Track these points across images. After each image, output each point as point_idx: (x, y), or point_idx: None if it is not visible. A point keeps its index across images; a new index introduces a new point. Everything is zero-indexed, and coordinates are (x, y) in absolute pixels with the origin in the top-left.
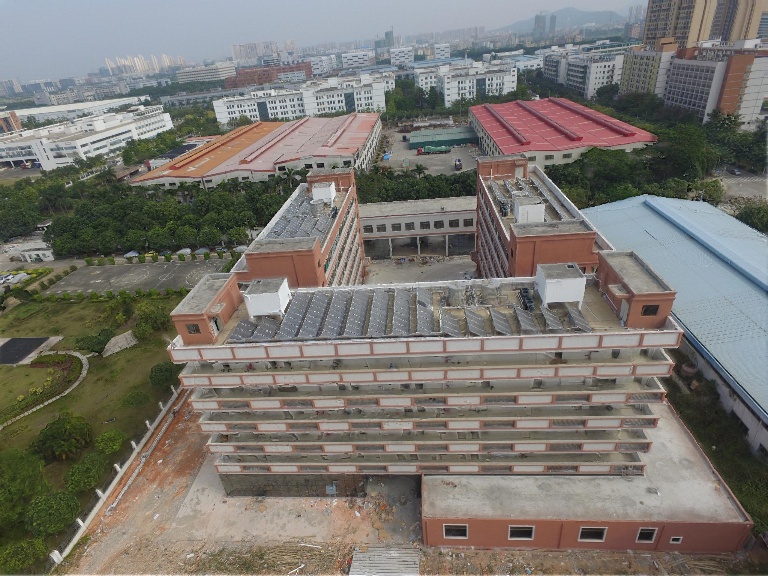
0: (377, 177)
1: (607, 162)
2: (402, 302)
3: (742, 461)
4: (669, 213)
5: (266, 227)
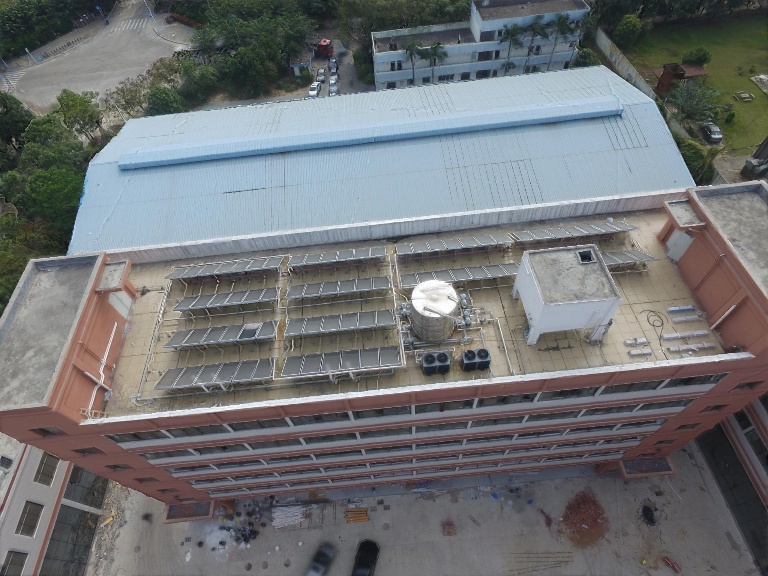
0: None
1: None
2: None
3: None
4: (197, 152)
5: None
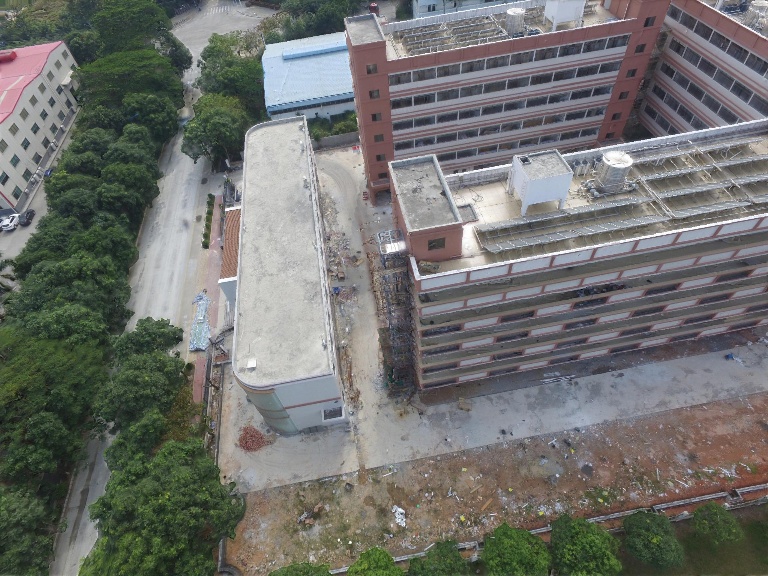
0: (7, 338)
1: (153, 65)
2: None
3: None
4: (331, 46)
5: (740, 219)
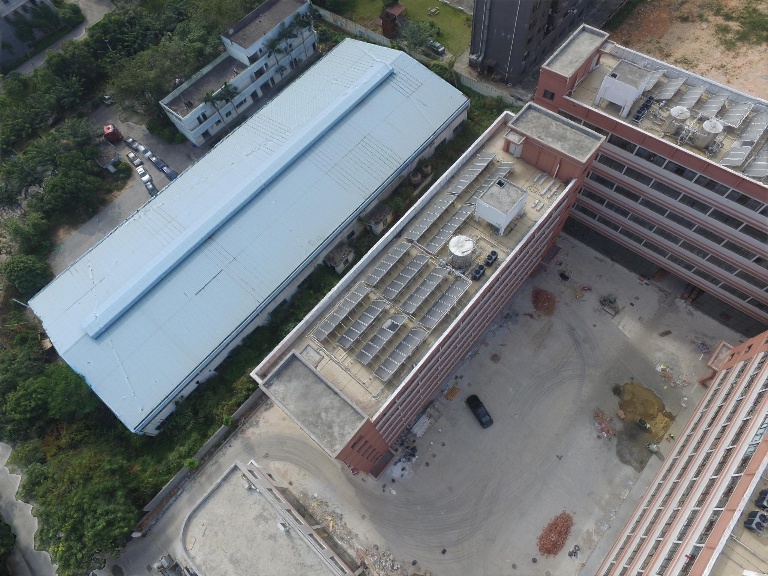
0: None
1: None
2: (765, 160)
3: (469, 136)
4: (147, 282)
5: None
